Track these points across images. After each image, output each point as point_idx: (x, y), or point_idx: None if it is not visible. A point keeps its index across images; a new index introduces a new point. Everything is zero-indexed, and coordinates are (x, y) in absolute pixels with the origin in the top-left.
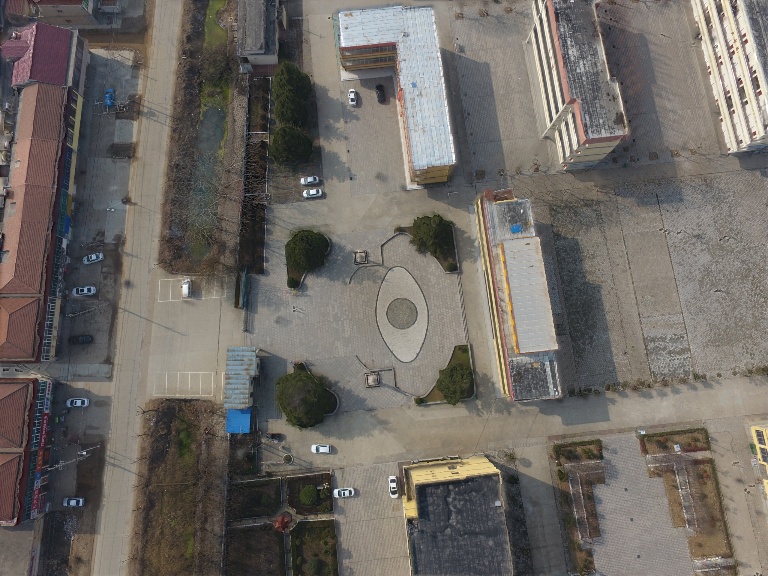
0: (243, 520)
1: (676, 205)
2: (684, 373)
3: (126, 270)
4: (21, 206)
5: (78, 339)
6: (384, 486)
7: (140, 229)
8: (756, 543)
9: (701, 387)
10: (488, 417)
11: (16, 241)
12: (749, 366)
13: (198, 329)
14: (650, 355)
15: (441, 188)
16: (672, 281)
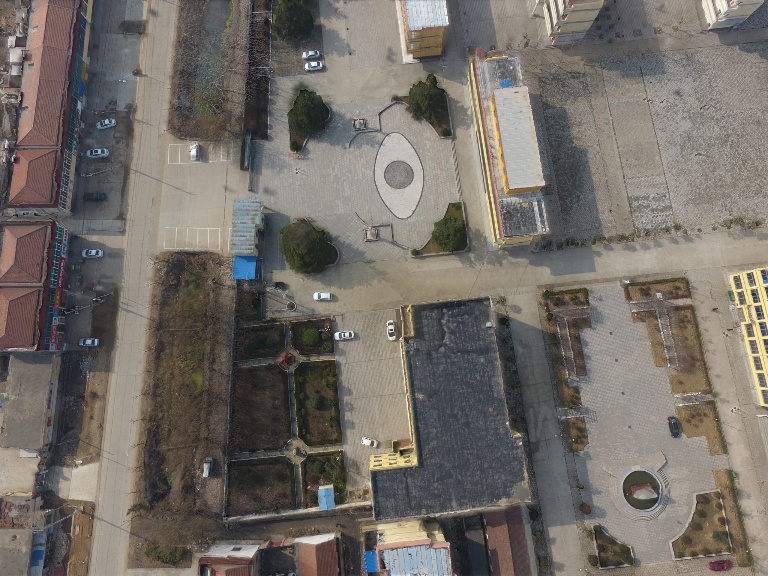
0: (249, 361)
1: (659, 77)
2: (666, 228)
3: (137, 135)
4: (39, 65)
5: (92, 196)
6: (382, 330)
7: (150, 98)
8: (734, 381)
9: (682, 241)
10: (480, 268)
11: (34, 97)
12: (728, 222)
13: (206, 189)
14: (634, 212)
15: (436, 62)
16: (655, 146)
